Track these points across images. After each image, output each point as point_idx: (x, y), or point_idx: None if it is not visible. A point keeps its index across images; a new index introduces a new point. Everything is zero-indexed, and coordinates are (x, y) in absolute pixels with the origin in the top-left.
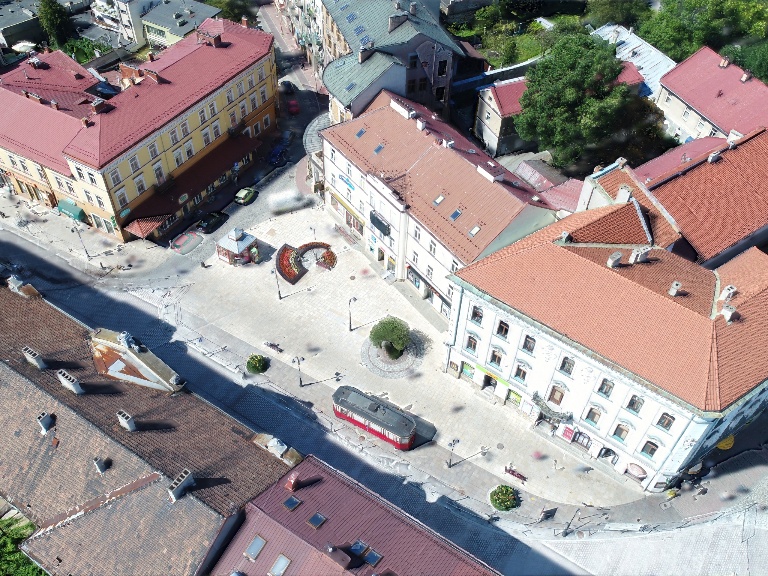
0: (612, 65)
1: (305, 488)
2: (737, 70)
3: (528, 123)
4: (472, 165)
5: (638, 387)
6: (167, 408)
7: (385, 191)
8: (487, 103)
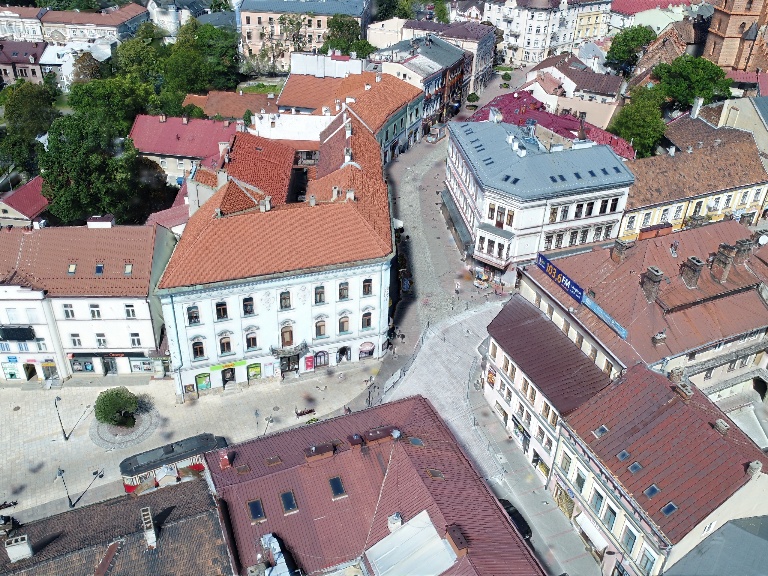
0: None
1: (235, 461)
2: (175, 119)
3: (72, 201)
4: (79, 227)
5: (340, 274)
6: None
7: (10, 293)
8: (4, 217)
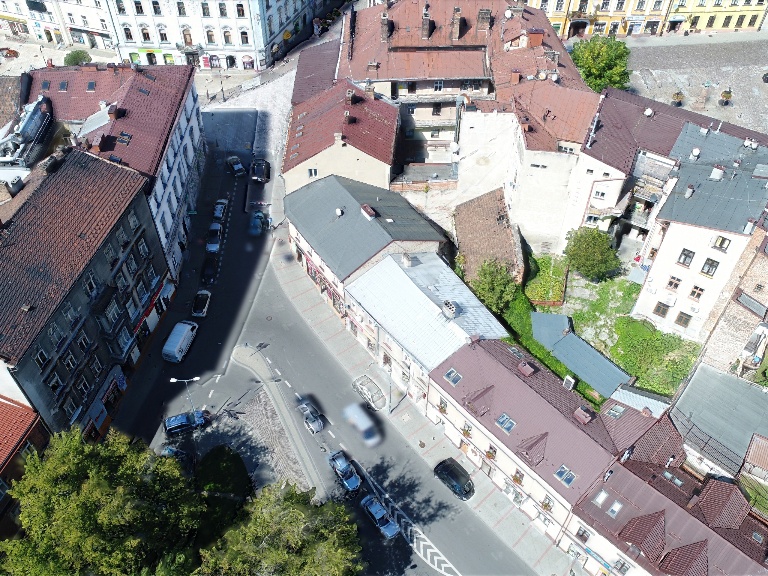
0: None
1: None
2: None
3: None
4: None
5: None
6: None
7: None
8: None
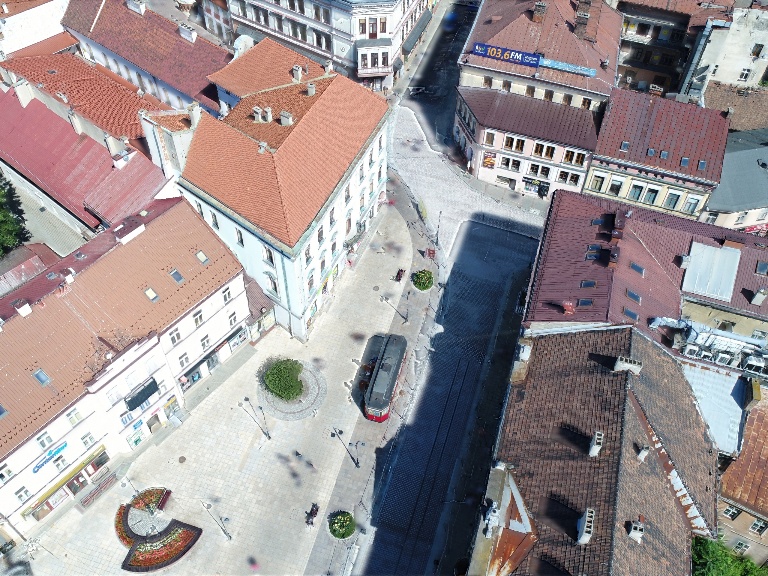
0: None
1: None
2: None
3: None
4: (113, 251)
5: None
6: (538, 454)
7: None
8: None
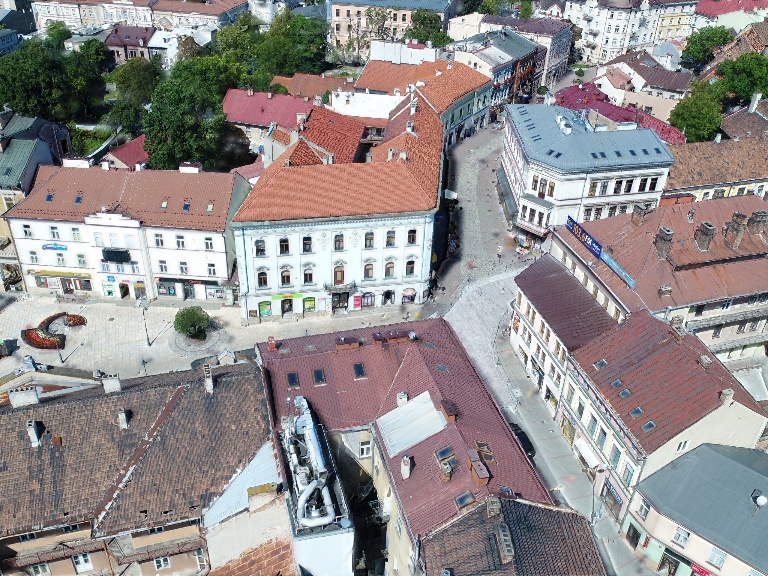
0: None
1: None
2: (261, 94)
3: (168, 155)
4: (172, 171)
5: (388, 223)
6: None
7: (114, 220)
8: None
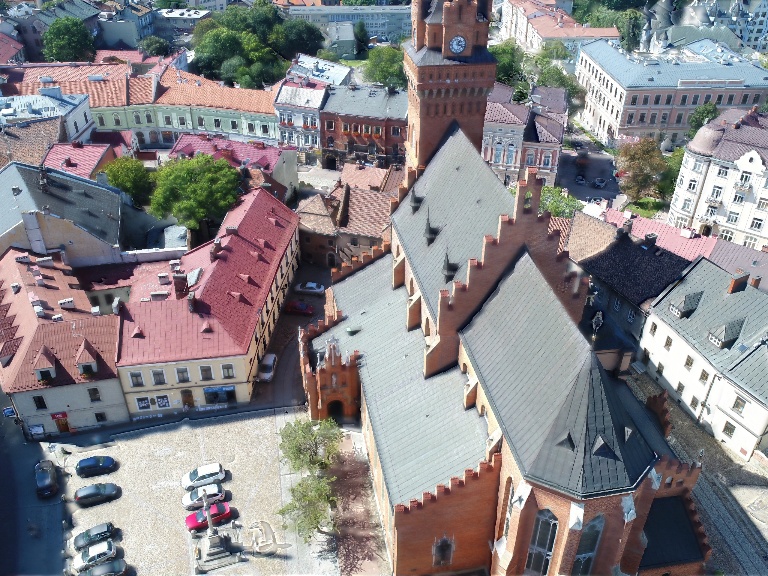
0: (73, 29)
1: None
2: None
3: None
4: None
5: None
6: None
7: None
8: None
